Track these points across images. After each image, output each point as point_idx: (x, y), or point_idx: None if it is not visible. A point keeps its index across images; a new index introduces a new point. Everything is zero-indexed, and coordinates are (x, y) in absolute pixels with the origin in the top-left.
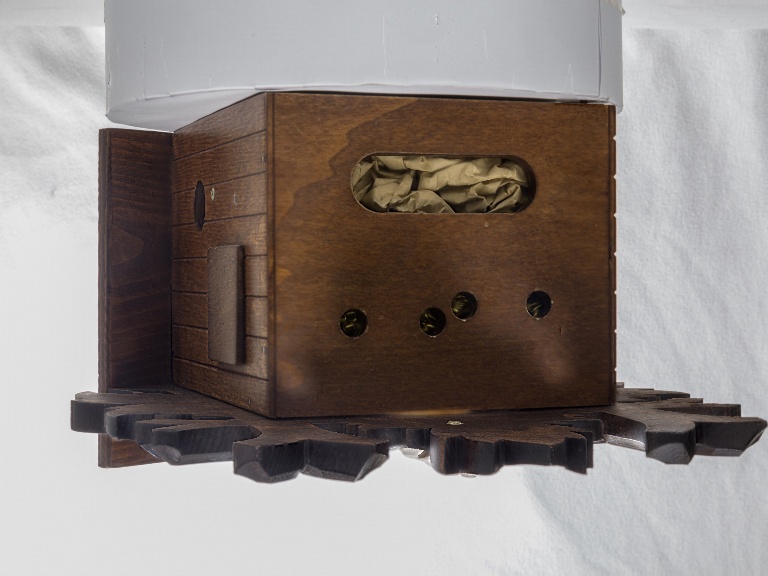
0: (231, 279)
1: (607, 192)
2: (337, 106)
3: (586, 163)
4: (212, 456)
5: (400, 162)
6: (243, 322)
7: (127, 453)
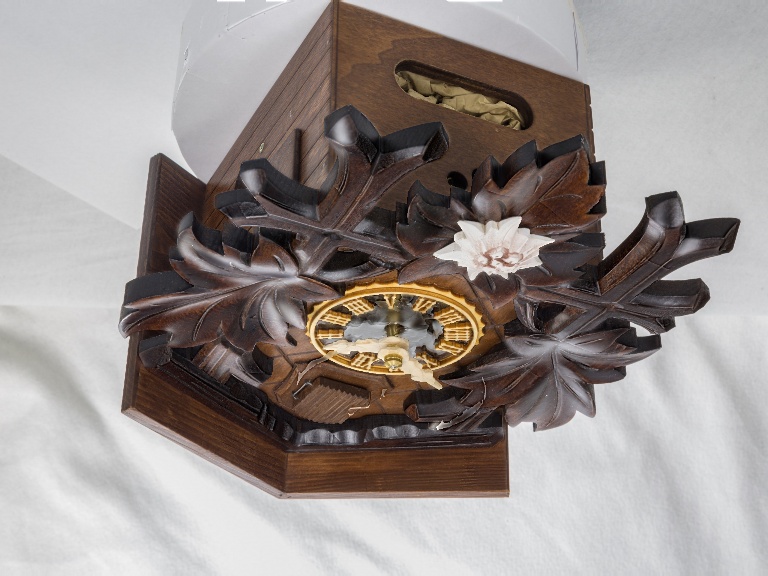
0: (287, 157)
1: (587, 138)
2: (384, 23)
3: (570, 114)
4: (286, 200)
5: (428, 84)
6: (298, 180)
7: (149, 405)
